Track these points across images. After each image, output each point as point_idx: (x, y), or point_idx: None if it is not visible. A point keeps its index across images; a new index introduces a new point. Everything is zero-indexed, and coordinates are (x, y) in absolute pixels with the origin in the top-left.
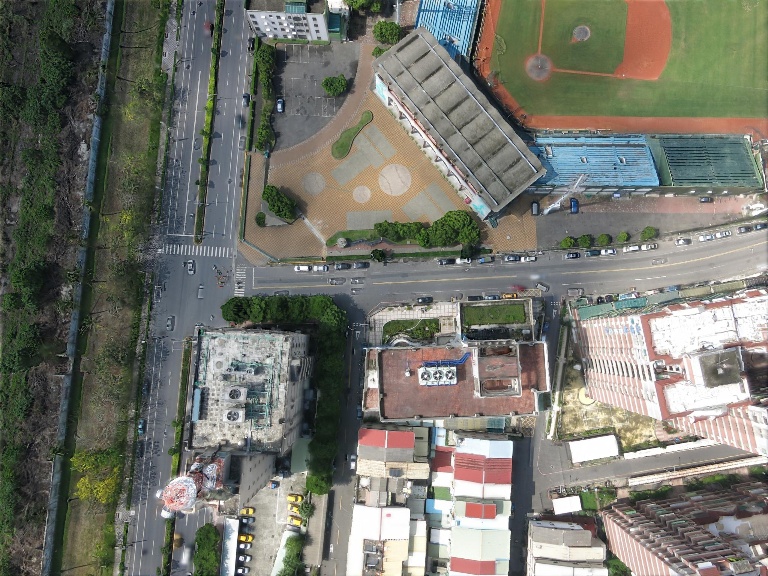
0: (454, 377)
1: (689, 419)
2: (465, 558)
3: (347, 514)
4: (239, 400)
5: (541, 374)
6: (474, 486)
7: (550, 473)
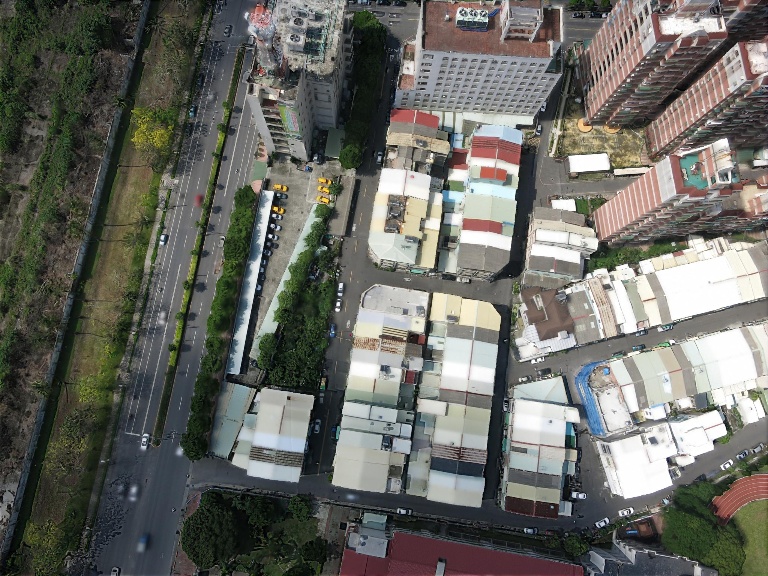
0: (486, 16)
1: (677, 45)
2: (476, 219)
3: (370, 200)
4: (301, 27)
5: (556, 32)
6: (488, 162)
7: (550, 184)
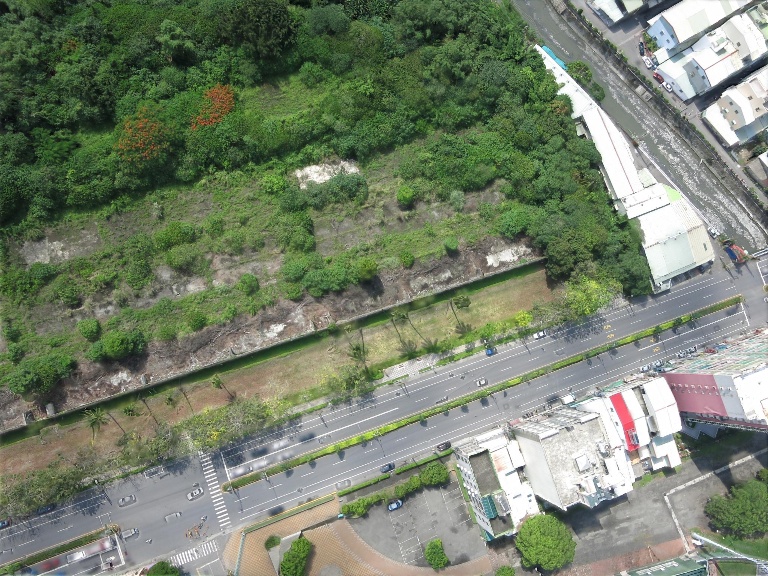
0: None
1: None
2: None
3: None
4: None
5: None
6: None
7: None
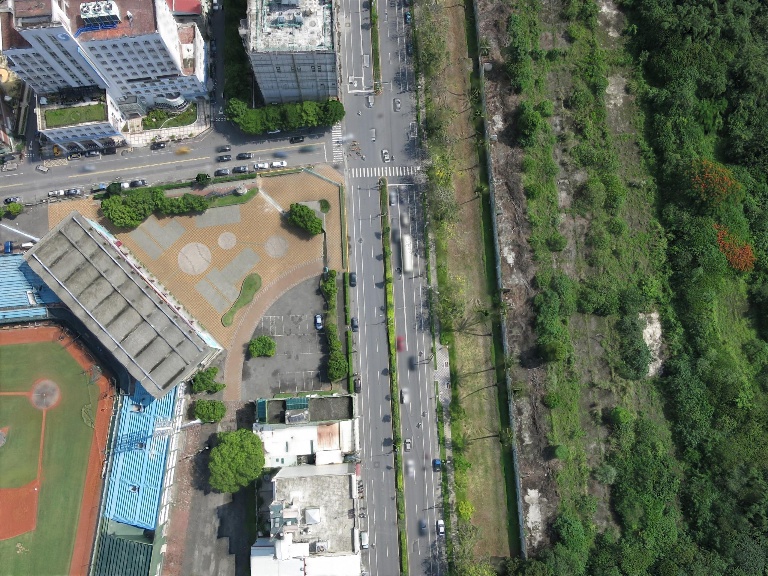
0: (82, 8)
1: None
2: None
3: None
4: None
5: (6, 26)
6: None
7: None
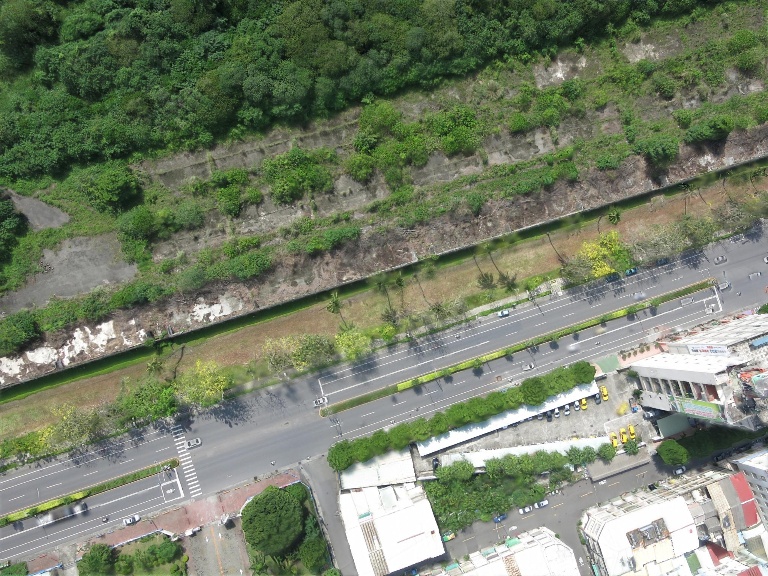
0: None
1: None
2: None
3: (635, 483)
4: None
5: None
6: None
7: None
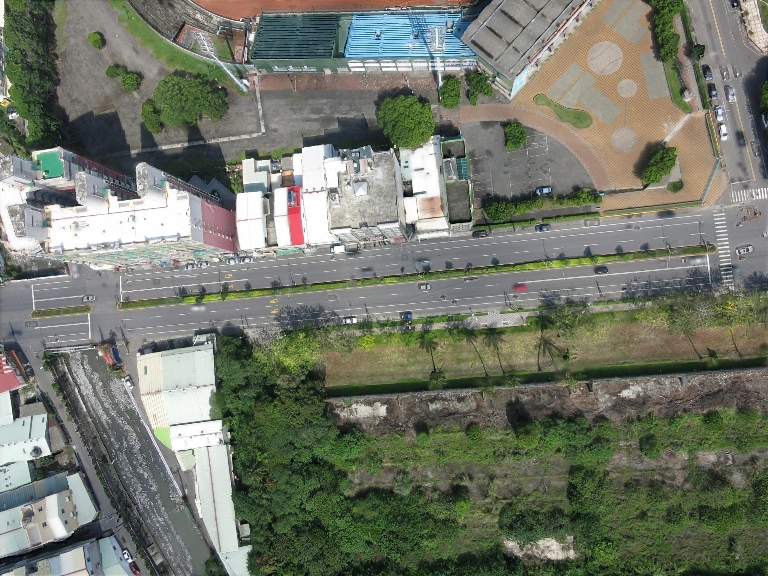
0: None
1: None
2: None
3: None
4: None
5: None
6: None
7: None
